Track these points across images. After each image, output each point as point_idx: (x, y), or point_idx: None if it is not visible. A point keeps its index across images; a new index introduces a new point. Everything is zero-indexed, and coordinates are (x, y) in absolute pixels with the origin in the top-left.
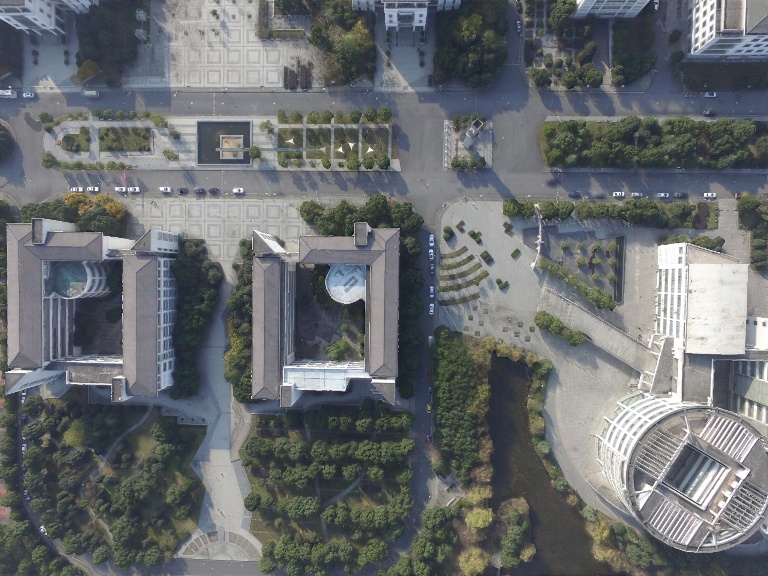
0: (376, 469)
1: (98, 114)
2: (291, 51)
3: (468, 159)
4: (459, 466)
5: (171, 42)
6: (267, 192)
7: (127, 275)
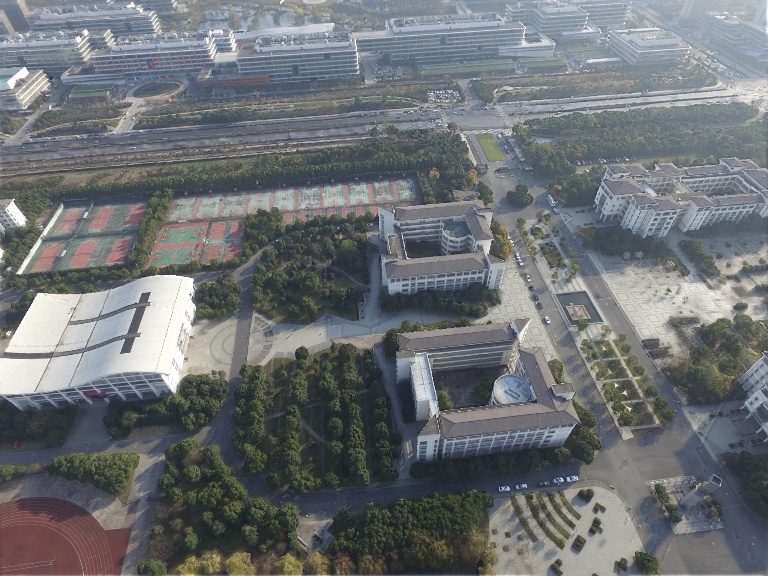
0: (341, 445)
1: (563, 239)
2: (673, 342)
3: (671, 503)
4: (348, 538)
5: (632, 271)
6: (555, 339)
7: (469, 255)
